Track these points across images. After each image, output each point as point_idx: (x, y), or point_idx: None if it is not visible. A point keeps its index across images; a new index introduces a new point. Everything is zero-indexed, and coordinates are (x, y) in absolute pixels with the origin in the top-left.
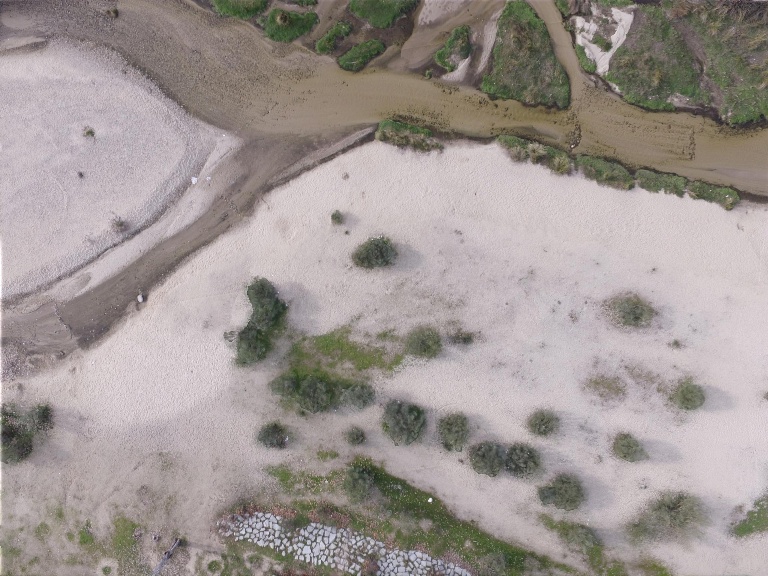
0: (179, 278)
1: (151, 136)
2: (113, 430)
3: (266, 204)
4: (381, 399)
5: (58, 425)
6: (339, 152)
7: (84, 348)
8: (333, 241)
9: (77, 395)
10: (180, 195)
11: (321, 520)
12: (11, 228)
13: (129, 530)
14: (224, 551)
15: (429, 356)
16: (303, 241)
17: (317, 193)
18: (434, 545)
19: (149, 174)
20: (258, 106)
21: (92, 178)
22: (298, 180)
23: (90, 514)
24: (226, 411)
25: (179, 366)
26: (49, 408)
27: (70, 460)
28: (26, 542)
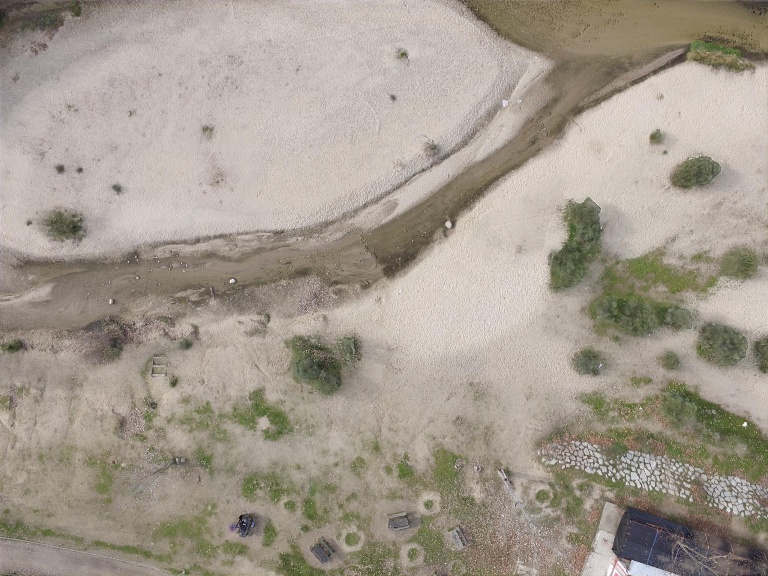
0: (490, 203)
1: (466, 58)
2: (422, 360)
3: (578, 126)
4: (695, 322)
5: (366, 357)
6: (651, 73)
7: (390, 277)
8: (651, 161)
9: (385, 325)
10: (490, 118)
11: (638, 447)
12: (320, 153)
13: (450, 461)
14: (551, 480)
15: (754, 274)
16: (620, 162)
17: (631, 114)
18: (750, 470)
19: (463, 96)
20: (570, 28)
21: (405, 101)
22: (610, 102)
23: (407, 446)
24: (538, 338)
25: (491, 292)
26: (356, 339)
27: (380, 392)
28: (342, 478)
